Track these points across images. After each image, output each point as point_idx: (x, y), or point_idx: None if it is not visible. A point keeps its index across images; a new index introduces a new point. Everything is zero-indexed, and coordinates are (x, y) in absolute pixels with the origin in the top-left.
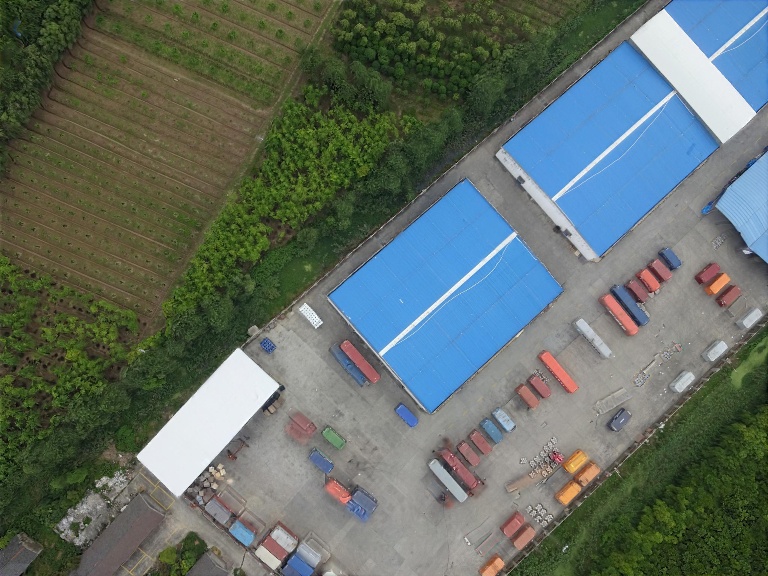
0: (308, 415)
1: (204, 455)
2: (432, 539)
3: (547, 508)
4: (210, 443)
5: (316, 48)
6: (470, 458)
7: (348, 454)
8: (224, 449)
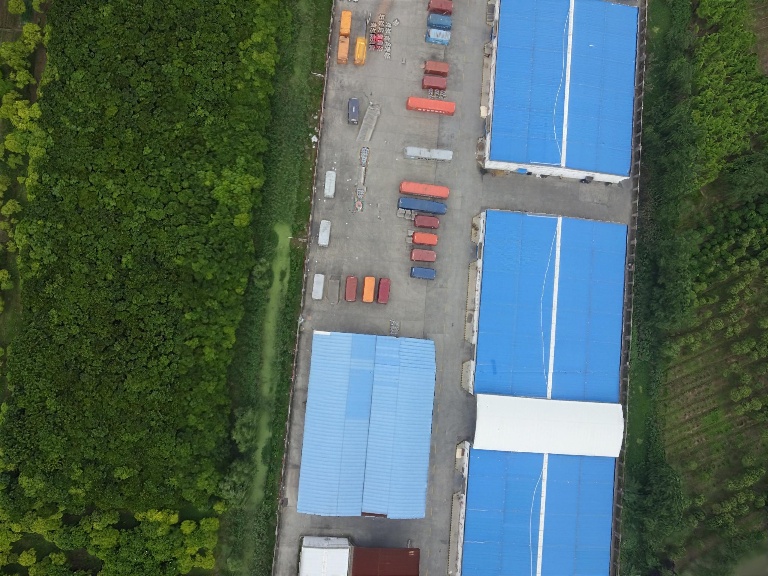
0: None
1: None
2: None
3: (349, 3)
4: None
5: None
6: None
7: None
8: None
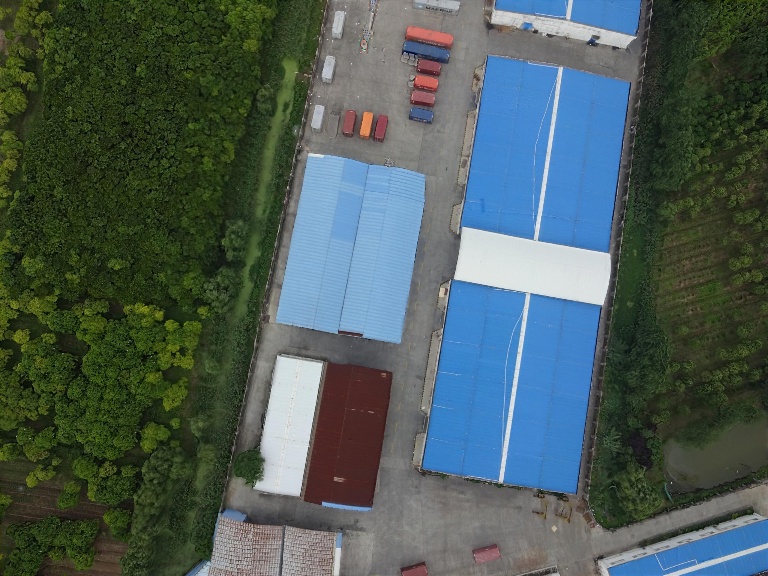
0: None
1: None
2: None
3: None
4: None
5: None
6: None
7: None
8: None
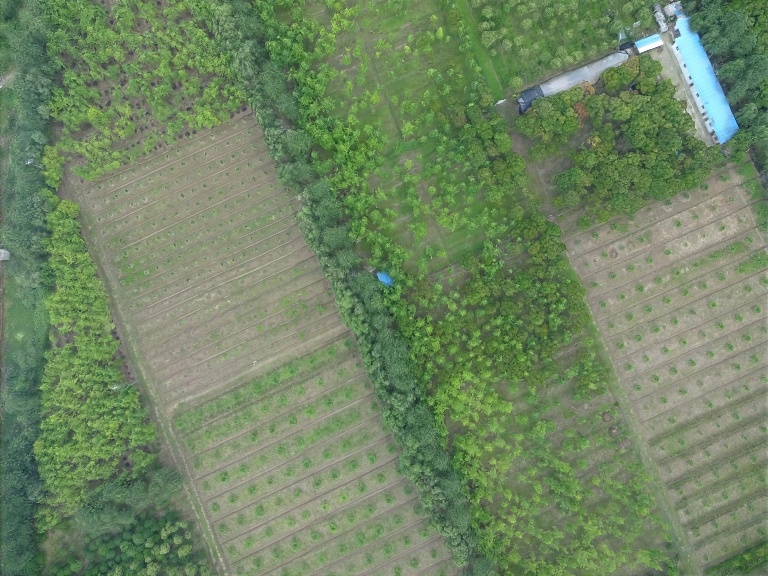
0: None
1: None
2: None
3: None
4: None
5: (190, 497)
6: None
7: None
8: None
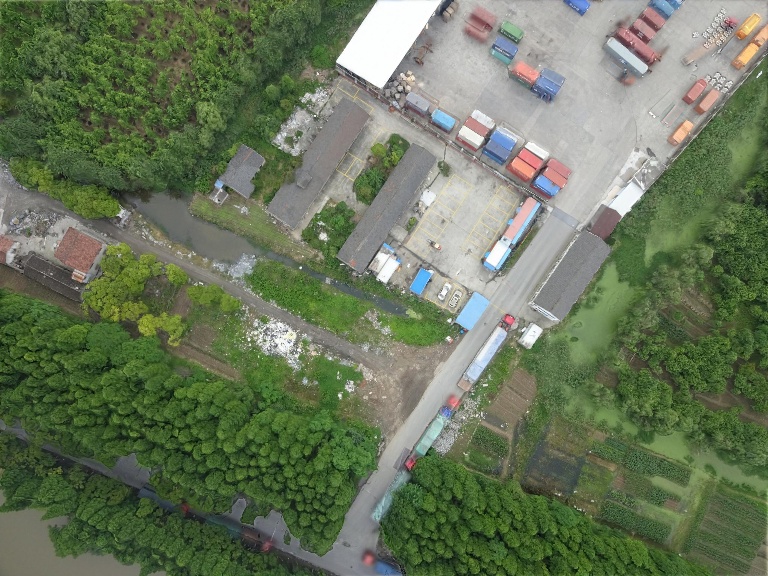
0: (482, 17)
1: (398, 50)
2: (618, 116)
3: (725, 76)
4: (401, 39)
5: None
6: (645, 32)
7: (526, 48)
8: (410, 57)
